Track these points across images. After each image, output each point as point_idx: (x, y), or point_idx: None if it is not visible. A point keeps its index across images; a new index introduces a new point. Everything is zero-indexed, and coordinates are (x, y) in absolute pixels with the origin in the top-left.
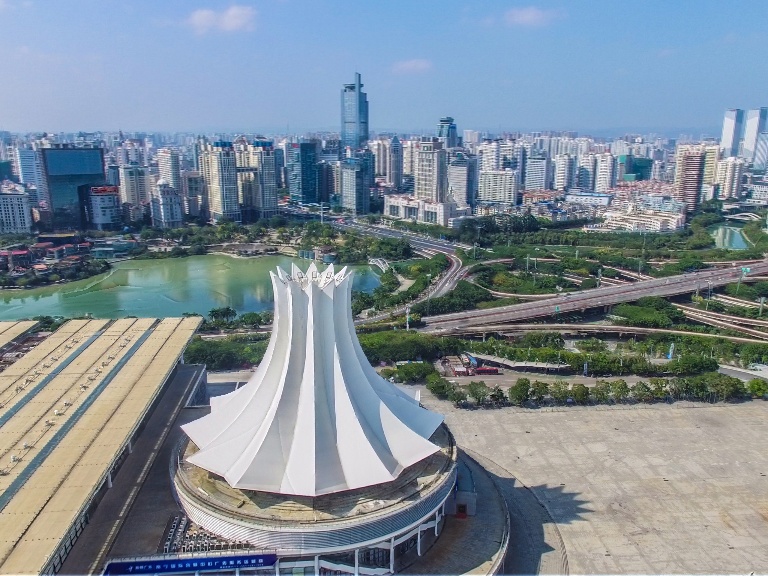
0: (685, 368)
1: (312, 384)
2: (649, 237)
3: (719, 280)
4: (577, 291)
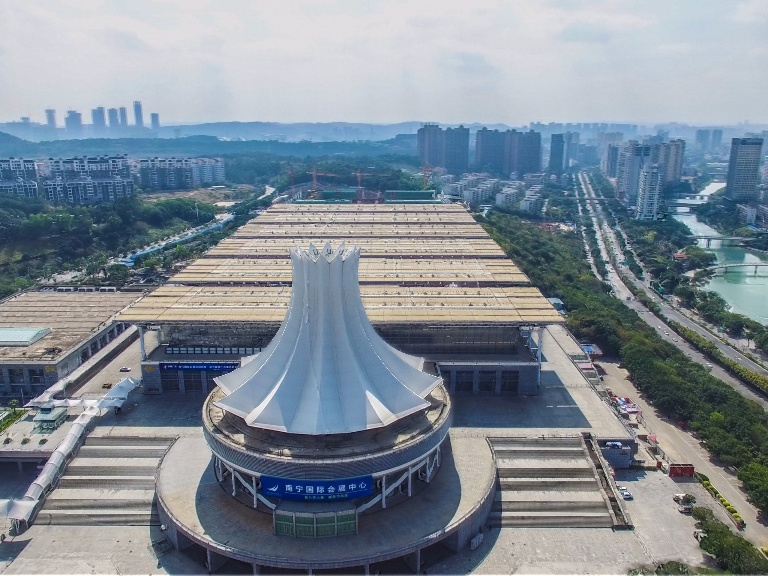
0: None
1: None
2: None
3: None
4: None
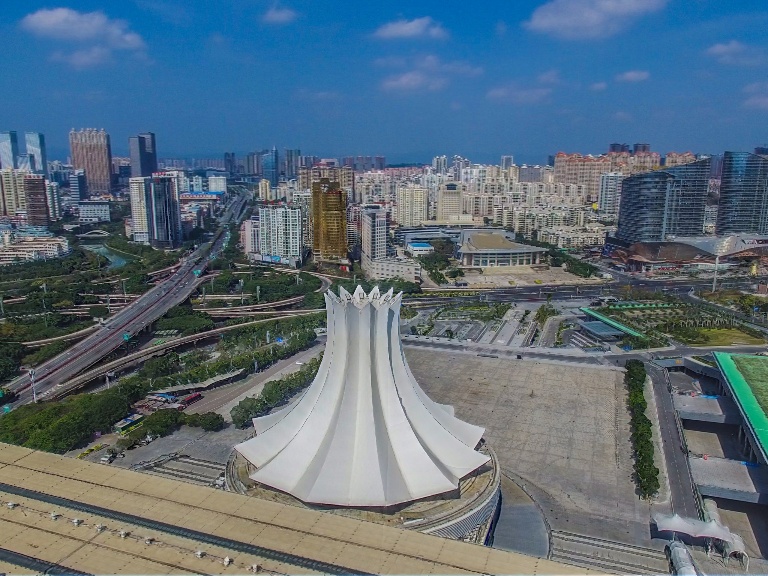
0: (305, 342)
1: (412, 388)
2: (55, 263)
3: (188, 284)
4: (106, 319)
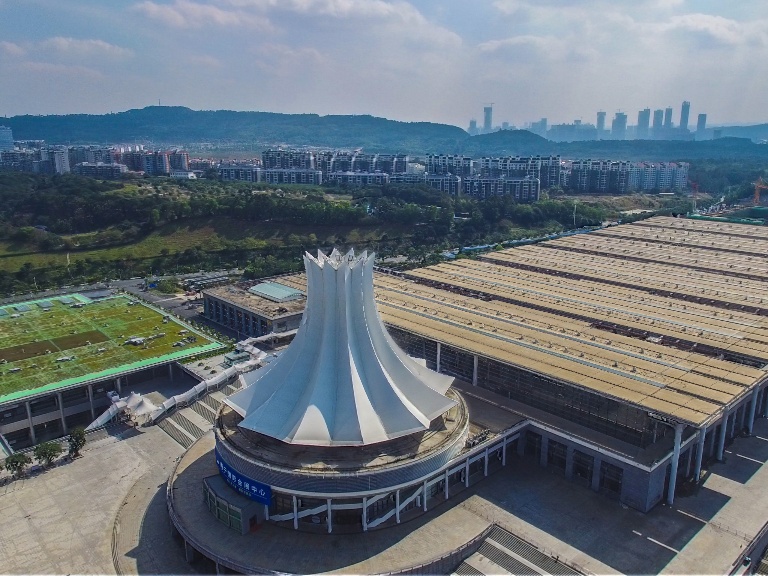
0: None
1: None
2: None
3: None
4: None
